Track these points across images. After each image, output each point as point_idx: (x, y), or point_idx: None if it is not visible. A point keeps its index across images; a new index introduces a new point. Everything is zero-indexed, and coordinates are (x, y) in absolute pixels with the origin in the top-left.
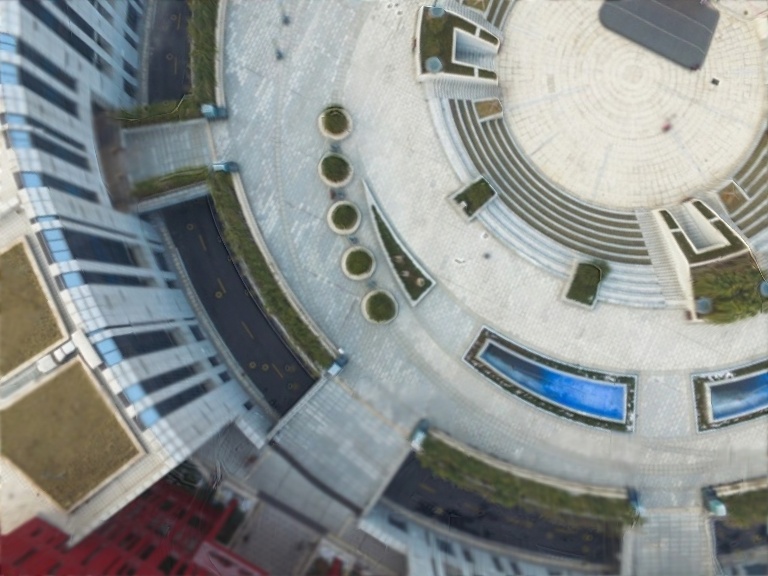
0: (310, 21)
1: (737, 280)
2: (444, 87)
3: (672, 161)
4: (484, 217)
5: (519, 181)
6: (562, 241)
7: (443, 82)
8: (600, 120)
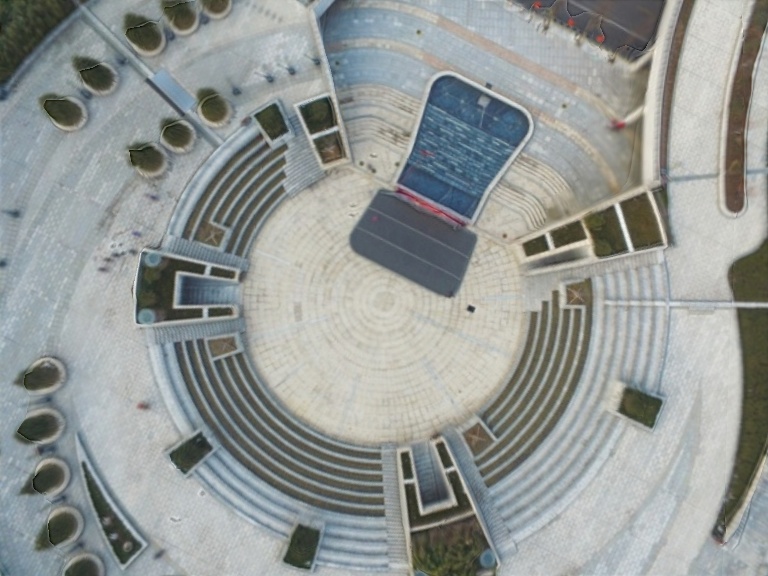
0: (28, 263)
1: (446, 559)
2: (168, 331)
3: (424, 392)
4: (201, 473)
5: (253, 422)
6: (290, 492)
7: (163, 329)
8: (349, 350)
